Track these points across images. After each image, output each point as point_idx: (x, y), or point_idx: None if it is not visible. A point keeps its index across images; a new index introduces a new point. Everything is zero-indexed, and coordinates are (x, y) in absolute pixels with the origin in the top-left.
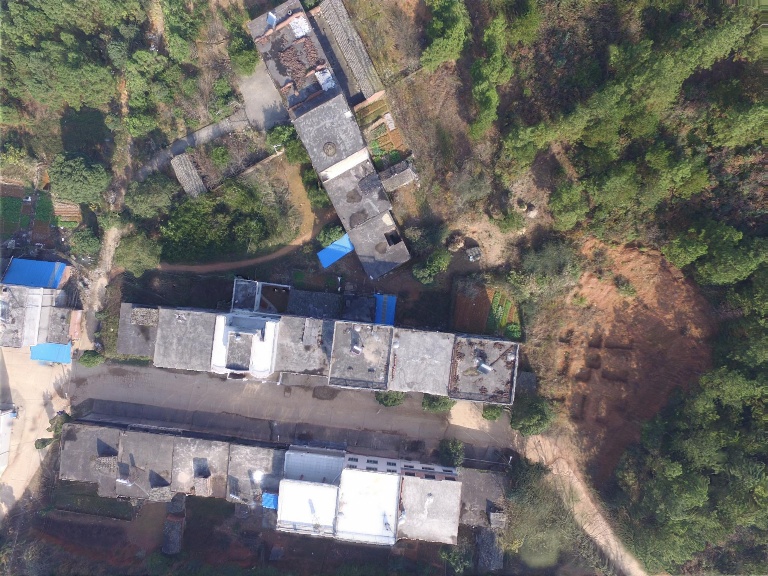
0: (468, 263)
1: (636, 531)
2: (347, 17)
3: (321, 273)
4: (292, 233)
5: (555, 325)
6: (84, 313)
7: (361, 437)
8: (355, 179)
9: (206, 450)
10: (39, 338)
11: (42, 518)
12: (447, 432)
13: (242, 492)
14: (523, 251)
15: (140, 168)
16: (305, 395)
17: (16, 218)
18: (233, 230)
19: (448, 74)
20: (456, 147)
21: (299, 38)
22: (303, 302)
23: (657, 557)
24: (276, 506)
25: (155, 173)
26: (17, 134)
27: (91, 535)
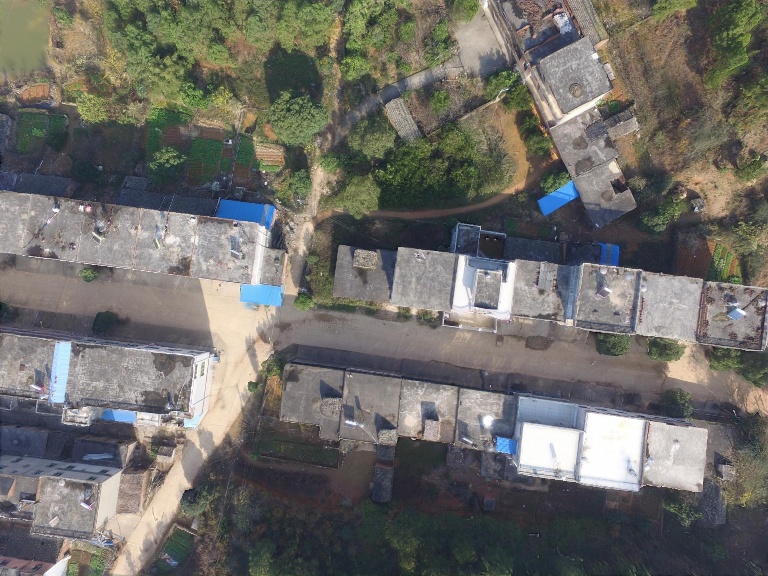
0: (689, 215)
1: None
2: None
3: (536, 222)
4: (505, 182)
5: None
6: (289, 257)
7: (575, 388)
8: (582, 126)
9: (434, 394)
10: (257, 278)
11: (243, 465)
12: (664, 385)
13: (472, 437)
14: (754, 202)
15: (348, 113)
16: (518, 345)
17: (216, 161)
18: (450, 176)
19: (679, 23)
20: (682, 97)
21: None
22: (523, 249)
23: None
24: (512, 451)
25: (363, 118)
26: (219, 76)
27: (294, 483)
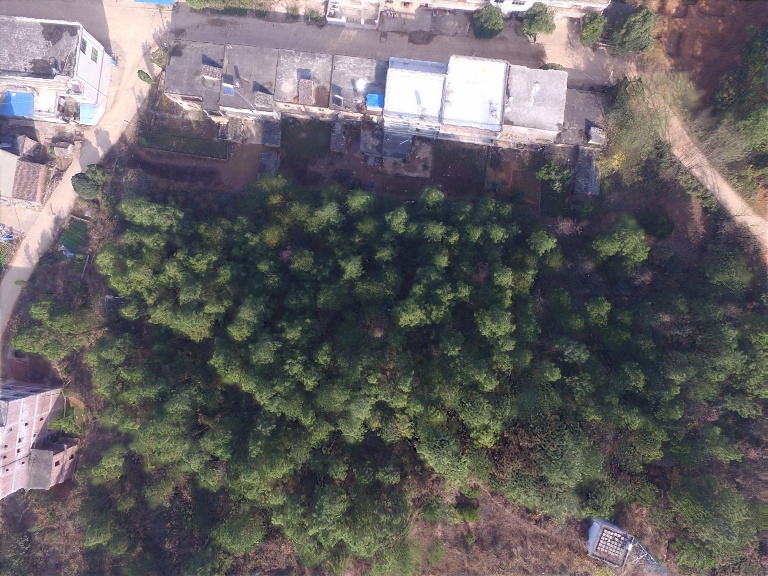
0: None
1: (745, 111)
2: None
3: None
4: None
5: None
6: None
7: None
8: None
9: (310, 61)
10: None
11: (137, 160)
12: None
13: (345, 100)
14: None
15: None
16: (401, 40)
17: None
18: None
19: None
20: None
21: None
22: None
23: (760, 164)
24: (380, 104)
25: None
26: None
27: (185, 176)
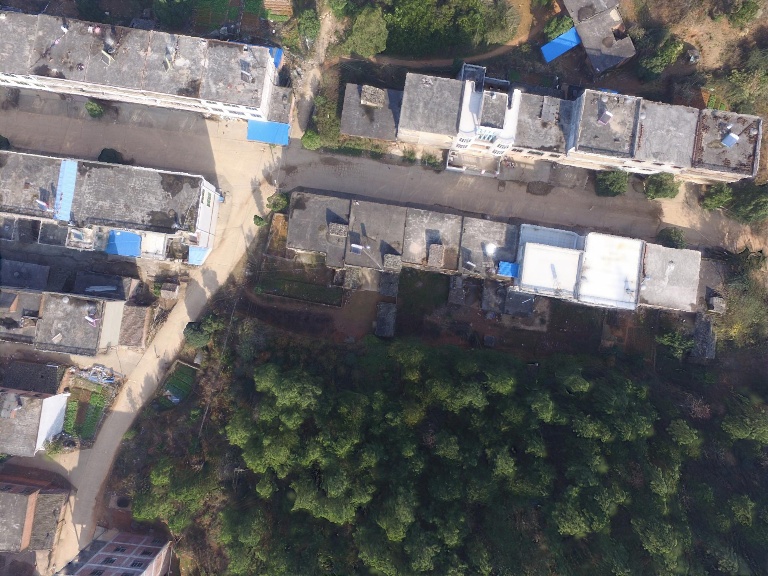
0: (685, 67)
1: None
2: None
3: (538, 72)
4: (509, 34)
5: (767, 128)
6: (296, 102)
7: None
8: None
9: (439, 222)
10: (265, 111)
11: (247, 303)
12: (659, 229)
13: None
14: (747, 49)
15: None
16: (519, 190)
17: (224, 9)
18: (457, 22)
19: None
20: None
21: None
22: None
23: None
24: (513, 274)
25: None
26: None
27: (297, 321)
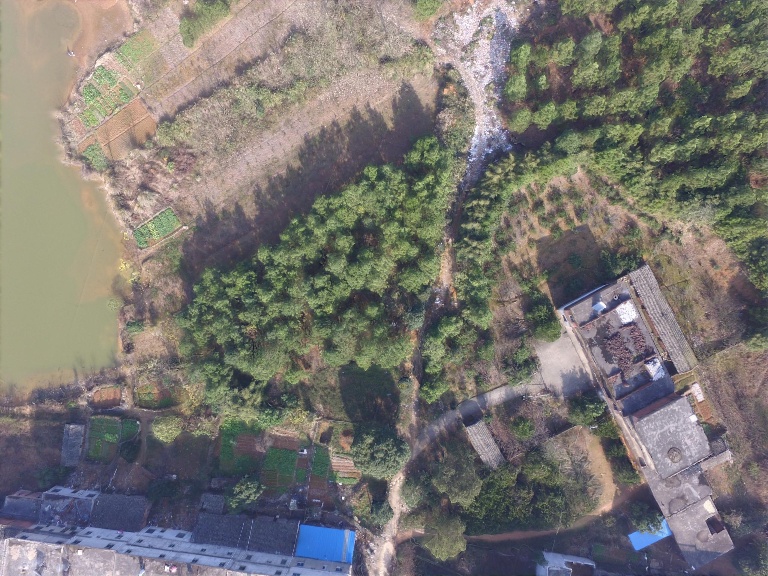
0: None
1: None
2: (658, 288)
3: (625, 549)
4: (591, 503)
5: None
6: None
7: None
8: None
9: None
10: None
11: None
12: None
13: None
14: None
15: (426, 427)
16: None
17: (291, 471)
18: (536, 505)
19: None
20: None
21: (626, 325)
22: None
23: None
24: None
25: (442, 433)
26: None
27: None
